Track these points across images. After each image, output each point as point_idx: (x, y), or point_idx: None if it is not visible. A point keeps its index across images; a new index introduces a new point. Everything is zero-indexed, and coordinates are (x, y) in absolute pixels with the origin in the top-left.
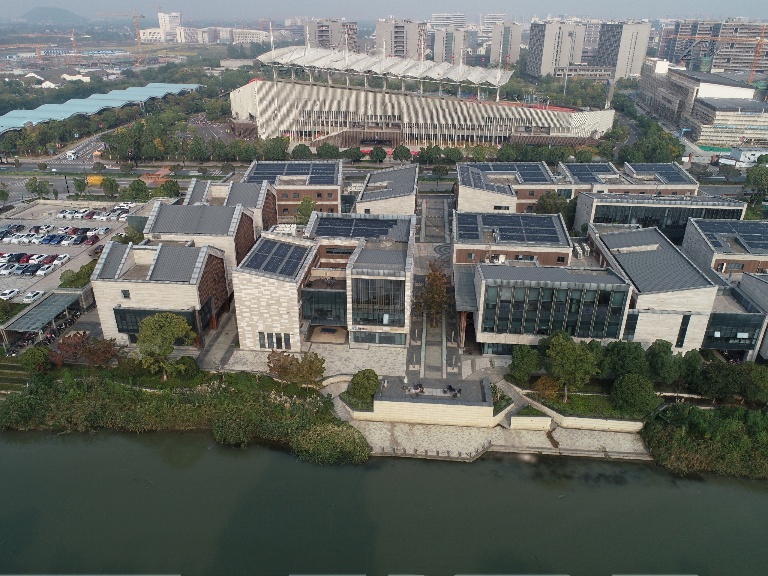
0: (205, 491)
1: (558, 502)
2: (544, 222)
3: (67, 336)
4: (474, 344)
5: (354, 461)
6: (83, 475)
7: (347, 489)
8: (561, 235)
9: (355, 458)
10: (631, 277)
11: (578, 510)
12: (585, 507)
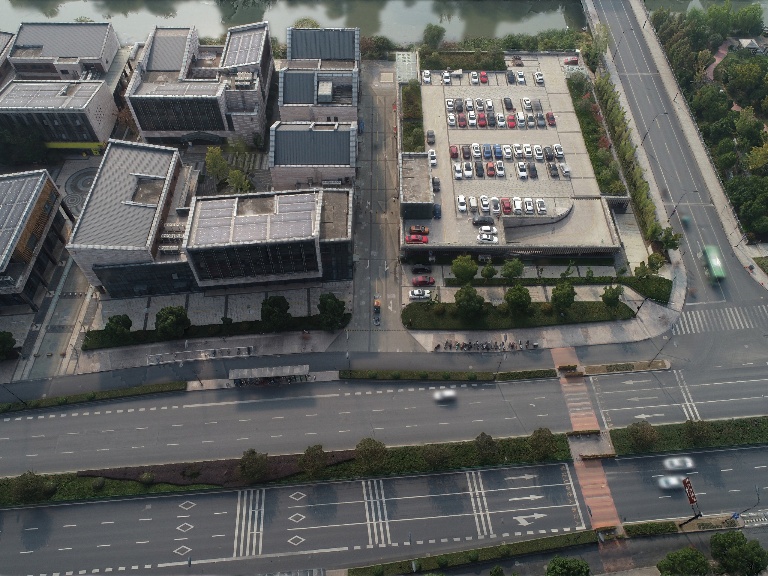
0: (274, 26)
1: (127, 31)
2: (9, 101)
3: (392, 77)
4: (126, 84)
5: (211, 37)
6: (328, 27)
7: (215, 32)
8: (7, 91)
9: (210, 37)
10: (3, 49)
11: (121, 29)
12: (117, 30)
